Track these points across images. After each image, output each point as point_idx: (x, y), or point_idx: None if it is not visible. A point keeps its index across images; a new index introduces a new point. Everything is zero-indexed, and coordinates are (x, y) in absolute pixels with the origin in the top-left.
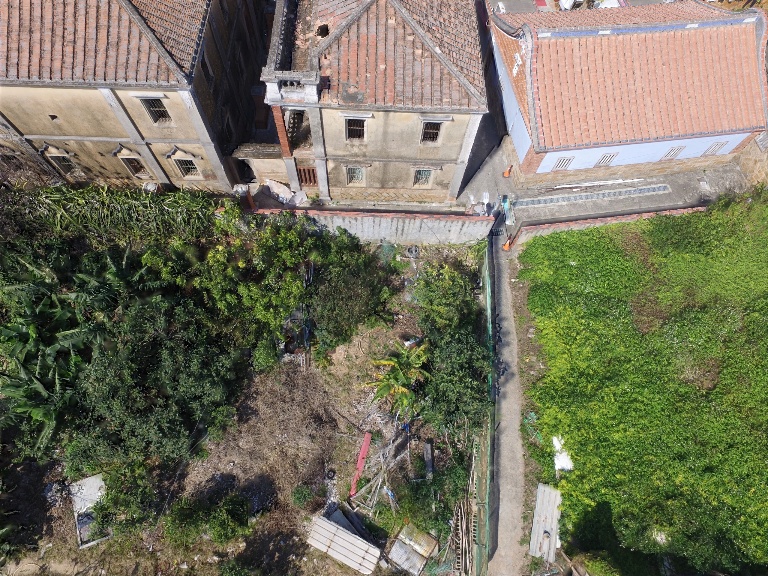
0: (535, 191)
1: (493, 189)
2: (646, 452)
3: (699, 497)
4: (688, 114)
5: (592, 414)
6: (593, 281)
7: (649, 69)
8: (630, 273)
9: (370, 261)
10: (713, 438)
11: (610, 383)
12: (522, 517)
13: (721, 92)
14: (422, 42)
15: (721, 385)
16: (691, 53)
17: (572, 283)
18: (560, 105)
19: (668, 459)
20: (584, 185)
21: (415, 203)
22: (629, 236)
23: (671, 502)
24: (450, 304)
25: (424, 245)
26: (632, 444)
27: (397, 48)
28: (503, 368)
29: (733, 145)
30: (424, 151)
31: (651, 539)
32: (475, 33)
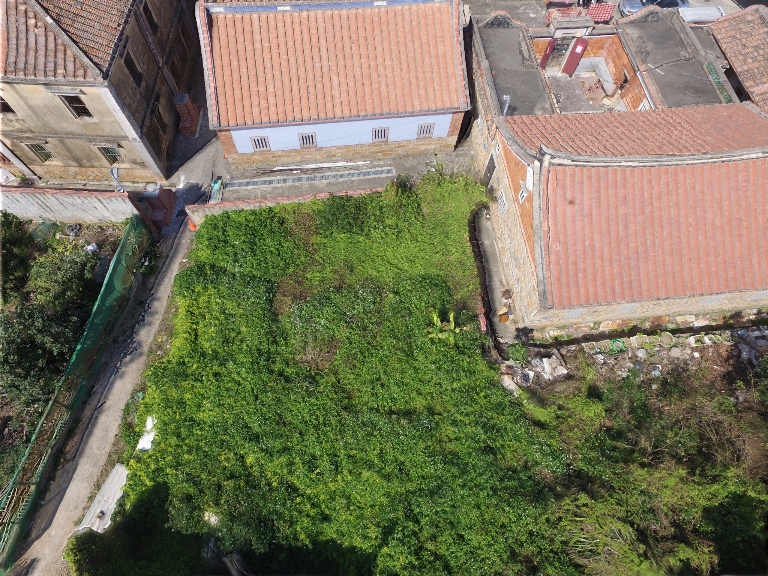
0: (253, 172)
1: (208, 170)
2: (223, 432)
3: (261, 478)
4: (377, 94)
5: (183, 393)
6: (241, 260)
7: (336, 47)
8: (284, 253)
9: (17, 238)
10: (296, 418)
11: (214, 362)
12: (88, 497)
13: (414, 72)
14: (34, 11)
15: (332, 366)
16: (382, 31)
17: (223, 263)
18: (237, 82)
19: (240, 439)
20: (305, 167)
21: (128, 183)
22: (301, 216)
23: (228, 482)
24: (58, 280)
25: (88, 223)
26: (213, 424)
27: (9, 17)
28: (133, 348)
29: (444, 127)
30: (87, 127)
31: (194, 519)
32: (124, 5)
